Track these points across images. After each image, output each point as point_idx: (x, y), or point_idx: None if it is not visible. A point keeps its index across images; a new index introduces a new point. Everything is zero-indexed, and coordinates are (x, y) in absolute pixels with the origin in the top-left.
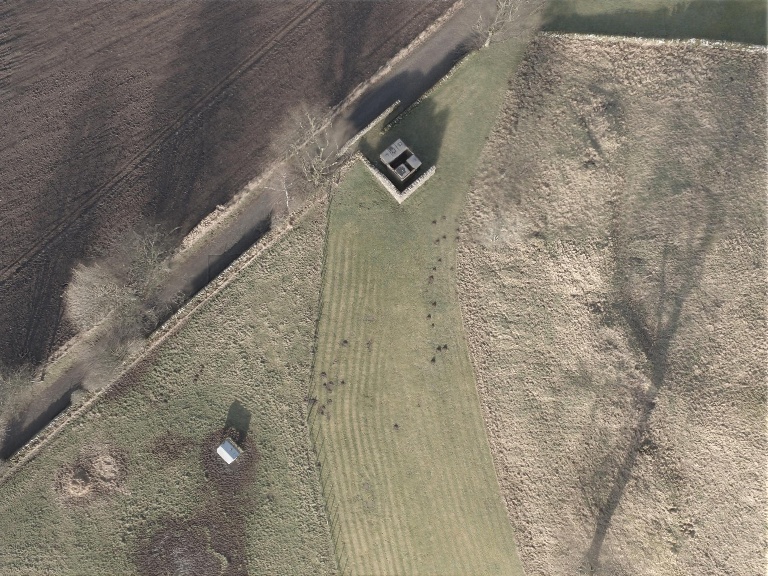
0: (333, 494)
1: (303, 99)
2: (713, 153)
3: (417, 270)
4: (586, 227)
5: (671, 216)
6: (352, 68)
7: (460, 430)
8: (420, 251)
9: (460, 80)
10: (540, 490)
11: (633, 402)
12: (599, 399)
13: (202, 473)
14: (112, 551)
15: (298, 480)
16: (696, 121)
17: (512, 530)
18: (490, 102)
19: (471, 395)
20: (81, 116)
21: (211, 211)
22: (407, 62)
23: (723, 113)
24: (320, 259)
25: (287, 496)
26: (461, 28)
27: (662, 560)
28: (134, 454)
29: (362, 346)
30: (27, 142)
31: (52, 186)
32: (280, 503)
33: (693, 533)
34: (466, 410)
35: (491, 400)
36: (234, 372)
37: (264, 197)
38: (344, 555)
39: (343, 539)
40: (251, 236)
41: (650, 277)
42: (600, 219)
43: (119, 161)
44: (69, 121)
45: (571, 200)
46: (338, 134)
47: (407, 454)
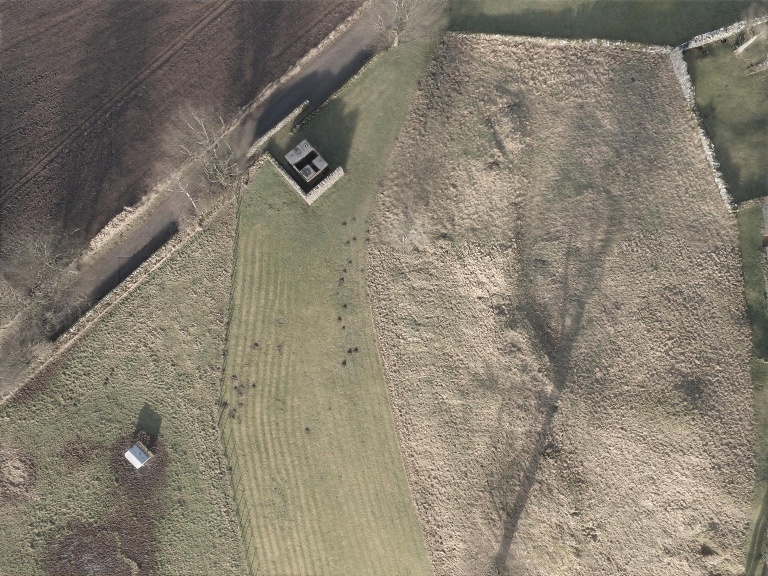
0: (244, 499)
1: (213, 99)
2: (613, 154)
3: (327, 272)
4: (491, 229)
5: (574, 218)
6: (262, 68)
7: (371, 434)
8: (330, 253)
9: (369, 80)
10: (450, 494)
11: (537, 405)
12: (505, 402)
13: (112, 478)
14: (20, 557)
15: (209, 484)
16: (598, 122)
17: (423, 534)
18: (400, 102)
19: (382, 398)
20: None
21: (119, 212)
22: (317, 62)
23: (624, 114)
24: (230, 261)
25: (198, 501)
26: (371, 28)
27: (566, 564)
28: (43, 459)
29: (273, 349)
30: None
31: None
32: (191, 508)
33: (595, 537)
34: (377, 413)
35: (401, 403)
36: (144, 375)
37: (174, 198)
38: (256, 560)
39: (255, 544)
40: (161, 238)
41: (554, 279)
42: (504, 221)
43: (27, 162)
44: None
45: (477, 201)
46: (248, 135)
47: (318, 458)
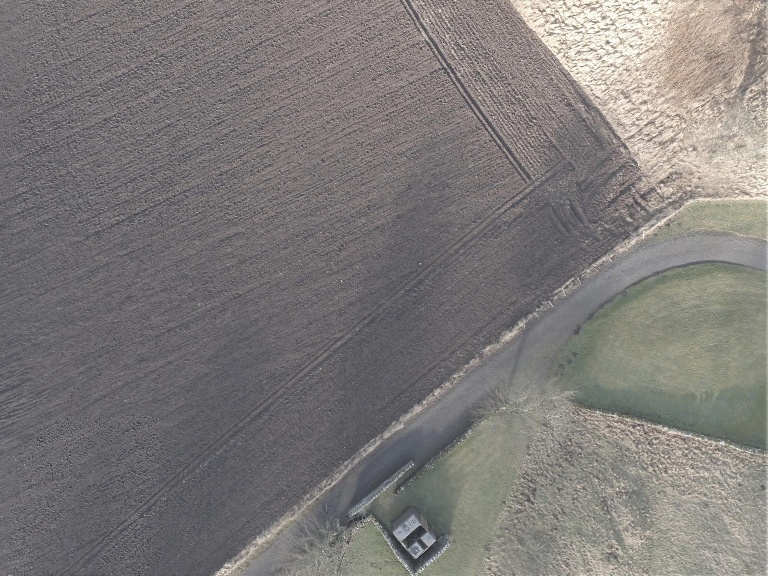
0: None
1: (313, 451)
2: (743, 569)
3: None
4: None
5: None
6: (364, 421)
7: None
8: None
9: (476, 442)
10: None
11: None
12: None
13: None
14: None
15: None
16: (725, 527)
17: None
18: (507, 465)
19: None
20: (86, 464)
21: (218, 565)
22: (421, 418)
23: (754, 525)
24: None
25: None
26: (478, 386)
27: None
28: None
29: None
30: (31, 492)
31: (56, 535)
32: None
33: None
34: None
35: None
36: None
37: (272, 550)
38: None
39: None
40: None
41: None
42: None
43: (124, 510)
44: (74, 470)
45: None
46: (349, 488)
47: None
